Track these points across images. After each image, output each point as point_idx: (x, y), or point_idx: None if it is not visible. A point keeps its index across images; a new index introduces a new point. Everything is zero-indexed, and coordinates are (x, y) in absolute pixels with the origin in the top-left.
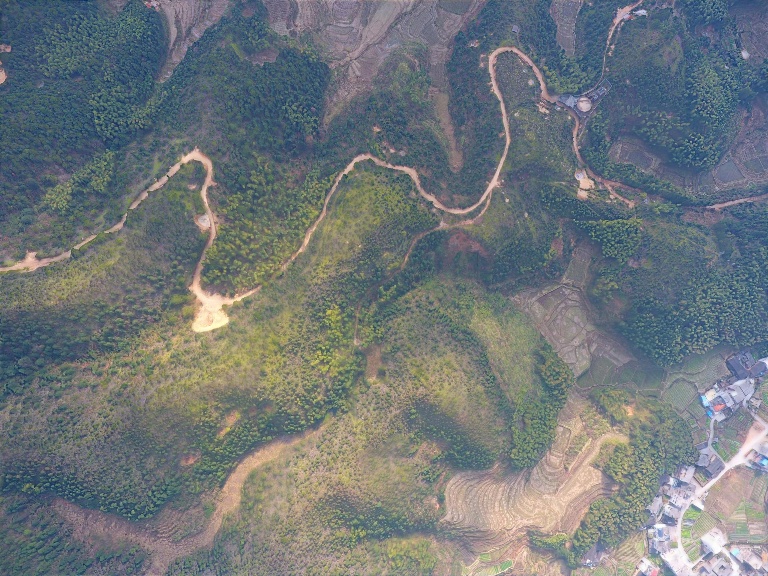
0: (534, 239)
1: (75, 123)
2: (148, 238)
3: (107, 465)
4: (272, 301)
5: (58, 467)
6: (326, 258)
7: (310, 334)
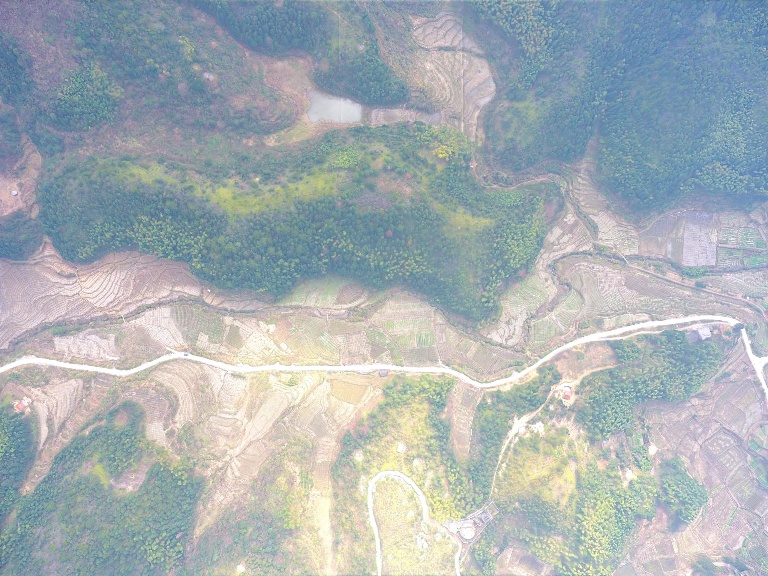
0: None
1: None
2: None
3: None
4: None
5: None
6: None
7: None
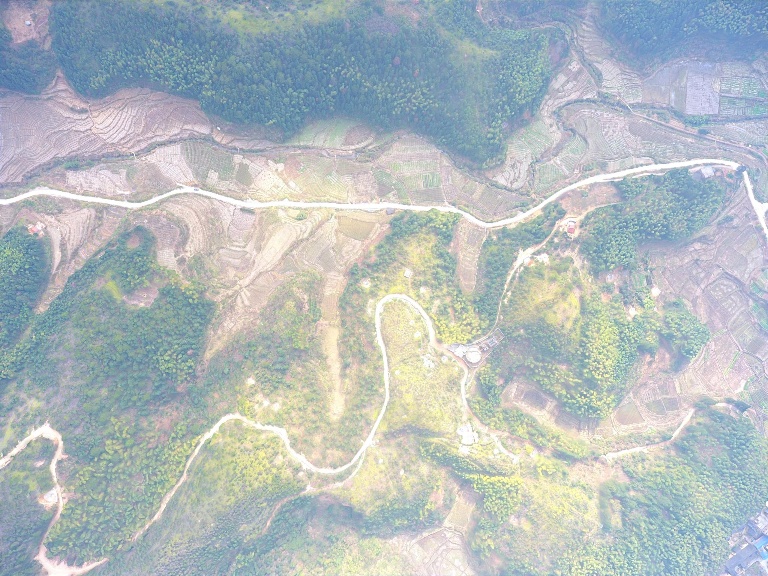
0: (409, 496)
1: None
2: None
3: None
4: None
5: None
6: (176, 536)
7: None
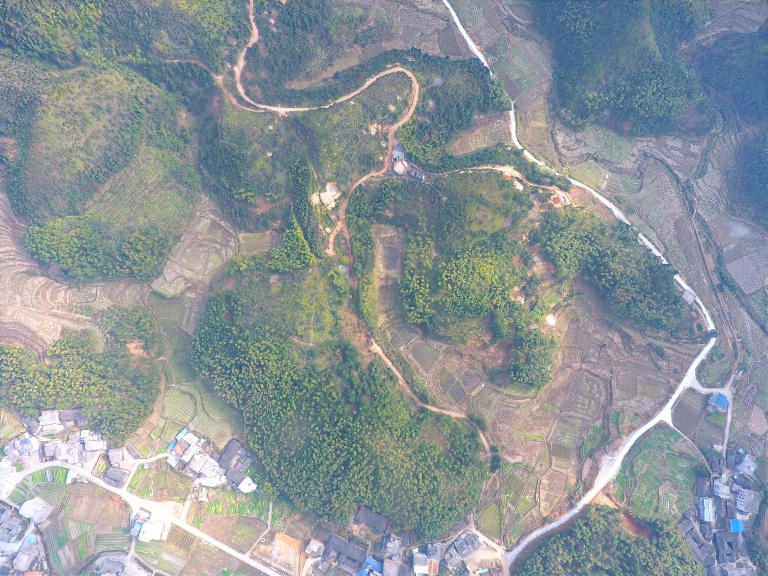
0: (251, 172)
1: None
2: None
3: None
4: None
5: None
6: None
7: None
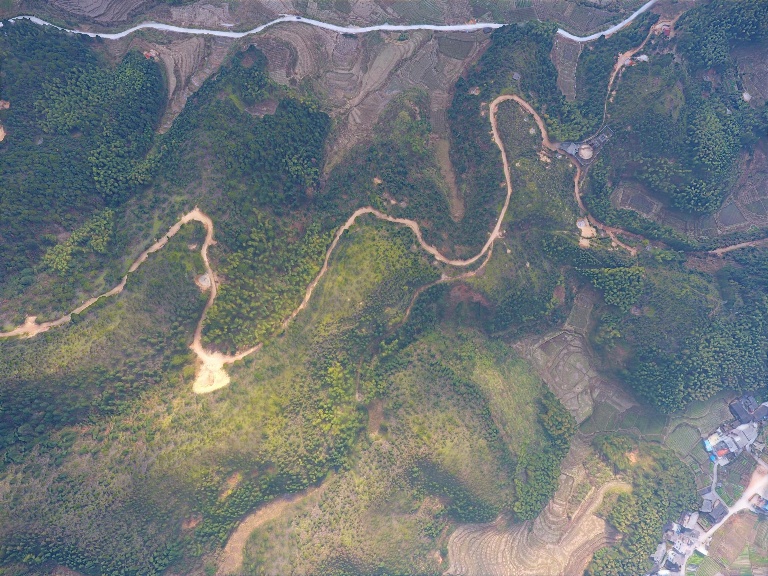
0: (536, 289)
1: (74, 181)
2: (148, 301)
3: (108, 534)
4: (273, 360)
5: (59, 538)
6: (327, 316)
7: (312, 393)
